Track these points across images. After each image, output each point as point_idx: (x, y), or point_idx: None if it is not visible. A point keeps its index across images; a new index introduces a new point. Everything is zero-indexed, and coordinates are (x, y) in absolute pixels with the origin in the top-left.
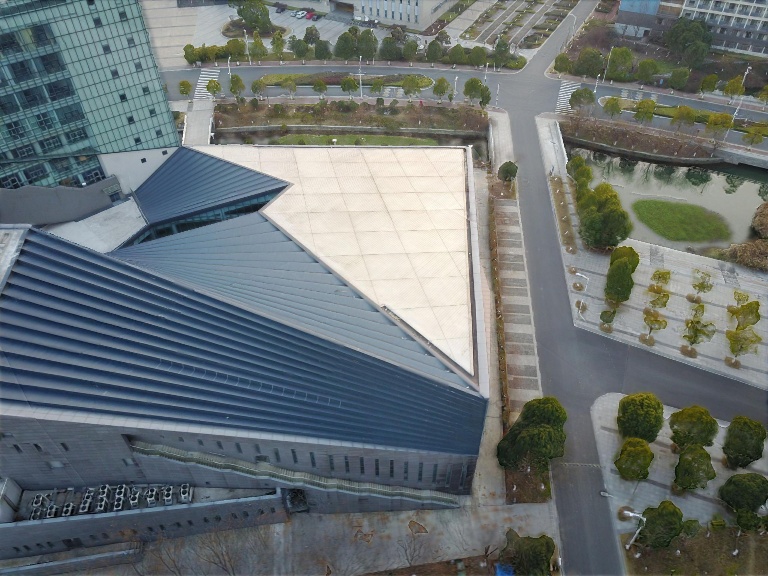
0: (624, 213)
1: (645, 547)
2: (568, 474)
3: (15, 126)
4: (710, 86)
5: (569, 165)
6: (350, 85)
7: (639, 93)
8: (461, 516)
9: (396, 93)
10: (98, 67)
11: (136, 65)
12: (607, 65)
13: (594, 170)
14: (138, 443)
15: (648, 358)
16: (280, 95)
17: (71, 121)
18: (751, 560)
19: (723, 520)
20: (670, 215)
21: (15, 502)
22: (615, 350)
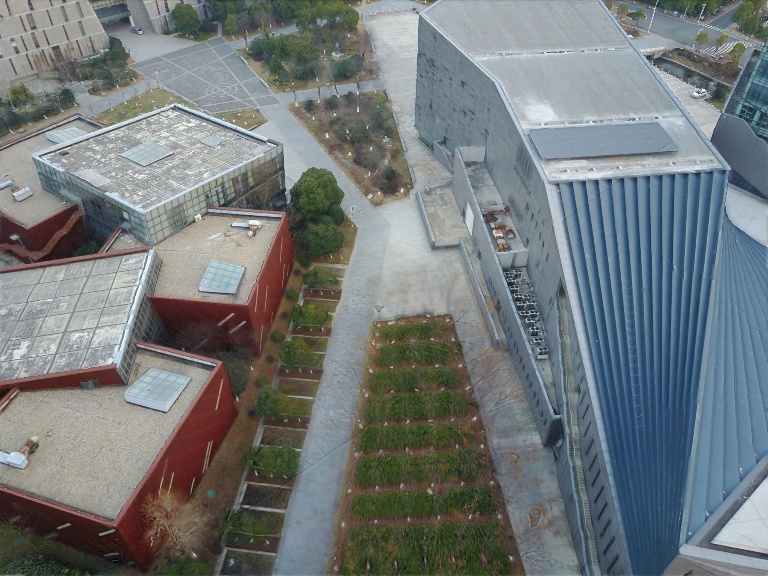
0: None
1: None
2: None
3: None
4: None
5: None
6: None
7: None
8: None
9: None
10: None
11: None
12: None
13: None
14: (563, 298)
15: None
16: None
17: None
18: None
19: None
20: None
21: (516, 264)
22: None
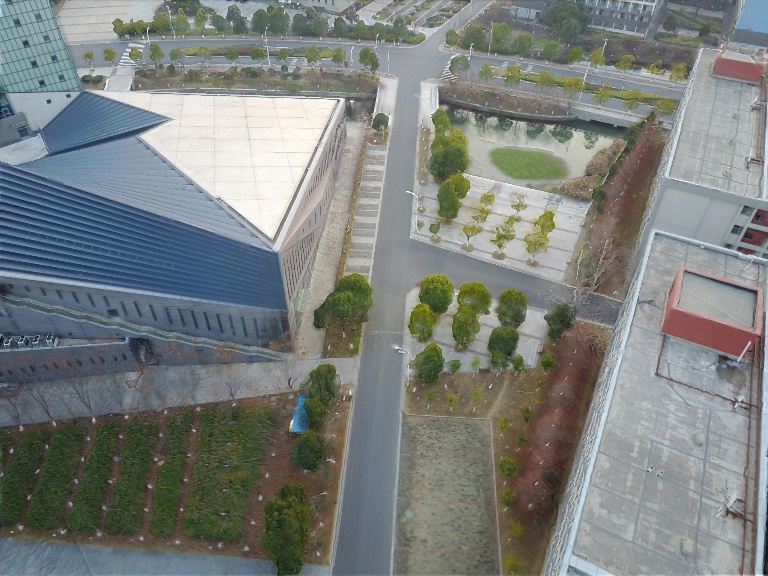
0: (461, 148)
1: (421, 384)
2: (376, 339)
3: None
4: (576, 57)
5: (432, 116)
6: (258, 54)
7: (518, 64)
8: (282, 367)
9: (302, 62)
10: (1, 15)
11: (36, 16)
12: (490, 39)
13: (472, 129)
14: (9, 296)
15: (464, 260)
16: (197, 63)
17: None
18: (501, 391)
19: (489, 367)
20: (520, 160)
21: None
22: (438, 254)
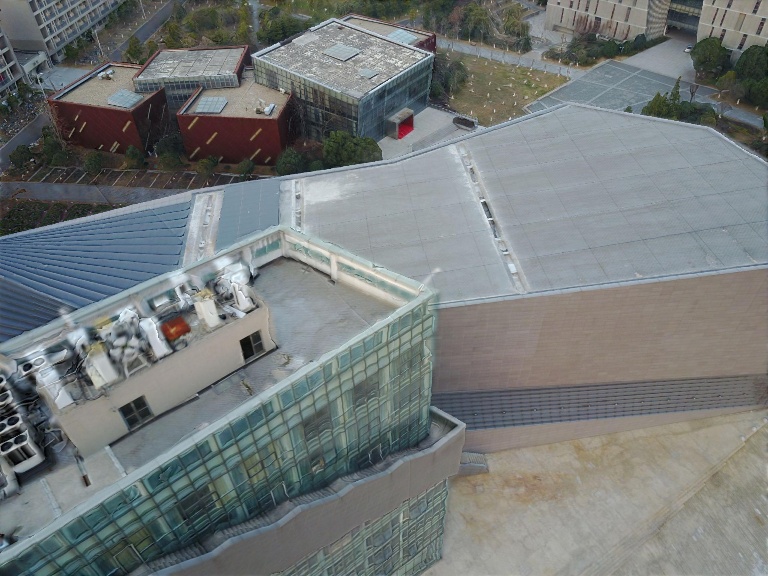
0: None
1: None
2: None
3: None
4: None
5: None
6: None
7: None
8: None
9: None
10: None
11: None
12: None
13: None
14: None
15: None
16: None
17: None
18: None
19: None
20: None
21: None
22: None
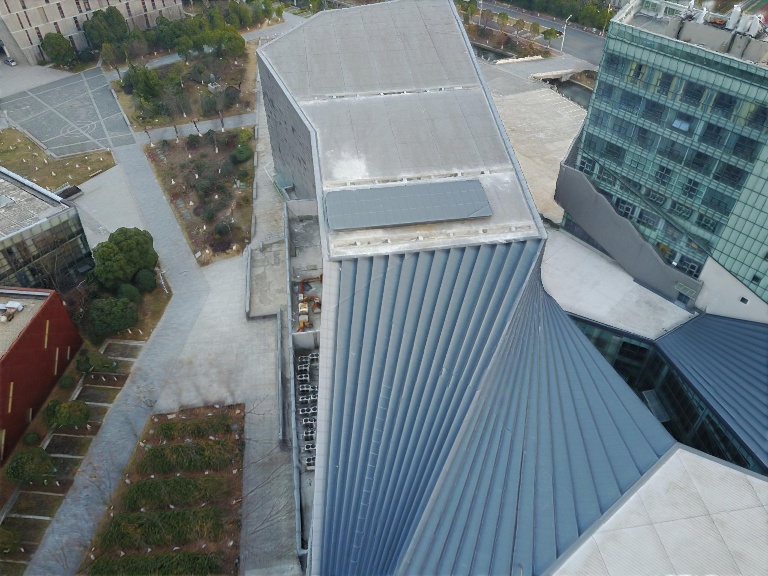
0: None
1: None
2: None
3: (666, 172)
4: None
5: None
6: None
7: None
8: None
9: None
10: None
11: None
12: None
13: None
14: None
15: None
16: None
17: (714, 208)
18: None
19: None
20: None
21: None
22: None
